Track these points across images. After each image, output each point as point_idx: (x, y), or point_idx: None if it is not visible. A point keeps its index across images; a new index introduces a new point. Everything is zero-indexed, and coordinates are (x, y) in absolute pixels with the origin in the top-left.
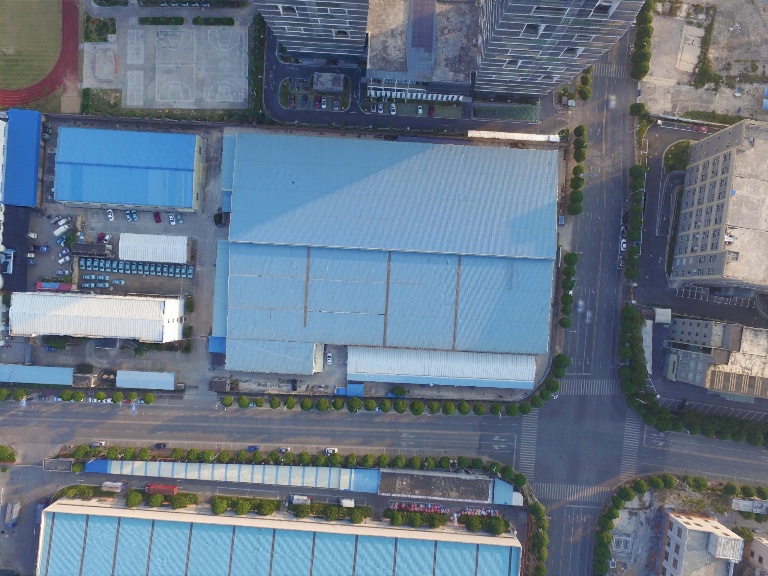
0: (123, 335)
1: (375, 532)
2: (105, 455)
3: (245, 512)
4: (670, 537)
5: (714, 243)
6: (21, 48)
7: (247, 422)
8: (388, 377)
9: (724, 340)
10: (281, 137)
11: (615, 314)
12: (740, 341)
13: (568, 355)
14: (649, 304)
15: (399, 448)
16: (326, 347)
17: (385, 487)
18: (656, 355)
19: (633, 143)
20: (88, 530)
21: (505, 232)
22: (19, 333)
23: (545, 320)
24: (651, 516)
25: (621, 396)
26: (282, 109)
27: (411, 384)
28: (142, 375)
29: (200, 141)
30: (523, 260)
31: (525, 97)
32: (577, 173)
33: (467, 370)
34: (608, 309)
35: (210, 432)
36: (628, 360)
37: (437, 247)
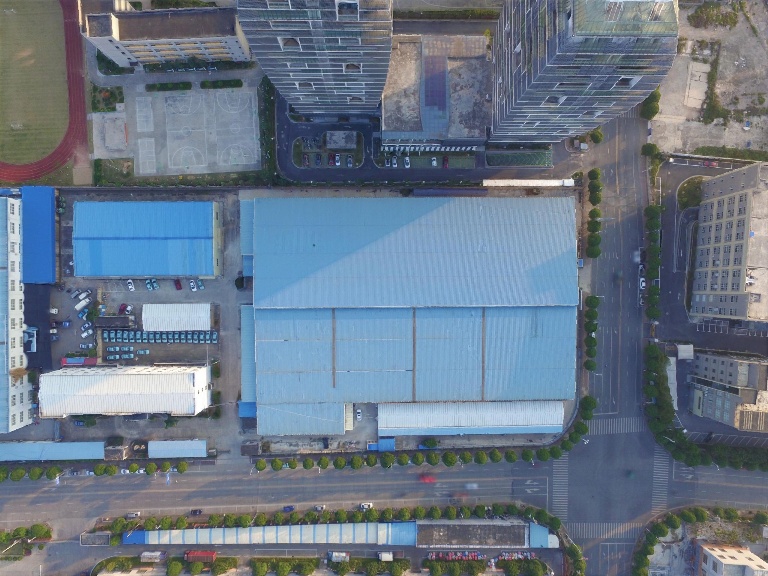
0: (154, 410)
1: None
2: (141, 525)
3: (286, 574)
4: (705, 570)
5: (735, 284)
6: (29, 122)
7: (281, 483)
8: (419, 430)
9: (750, 379)
10: (299, 200)
11: (638, 352)
12: (766, 380)
13: (594, 395)
14: (671, 340)
15: (433, 498)
16: (355, 403)
17: (422, 539)
18: (680, 390)
19: (646, 182)
20: None
21: (527, 282)
22: (50, 415)
23: (571, 365)
24: (684, 548)
25: (648, 432)
26: (296, 169)
27: (441, 434)
28: (174, 444)
29: (216, 206)
30: (546, 308)
31: (538, 144)
32: (594, 217)
33: (496, 418)
34: (631, 348)
35: (245, 495)
36: (654, 397)
37: (461, 301)
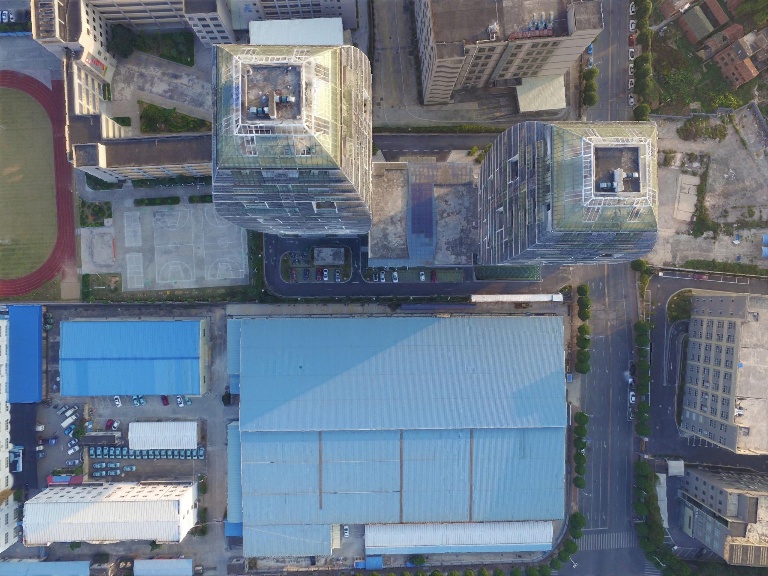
0: (139, 537)
1: None
2: None
3: None
4: None
5: (724, 412)
6: (17, 237)
7: None
8: (406, 549)
9: (740, 509)
10: (285, 321)
11: (628, 466)
12: (756, 513)
13: (584, 510)
14: (661, 455)
15: None
16: None
17: None
18: (671, 505)
19: (636, 295)
20: None
21: (515, 403)
22: (34, 543)
23: (560, 486)
24: None
25: (639, 548)
26: (284, 283)
27: None
28: (159, 563)
29: (204, 323)
30: (534, 429)
31: None
32: (582, 334)
33: (485, 537)
34: (621, 462)
35: None
36: None
37: (448, 424)
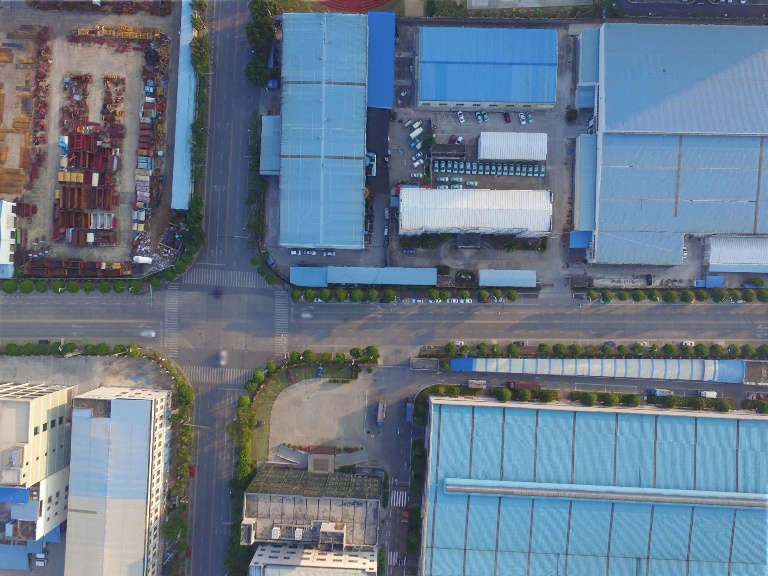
0: (511, 226)
1: (755, 417)
2: None
3: (616, 403)
4: None
5: None
6: None
7: (602, 318)
8: (750, 267)
9: None
10: (648, 26)
11: None
12: None
13: None
14: None
15: (754, 340)
16: None
17: (751, 376)
18: None
19: None
20: (475, 421)
21: None
22: (409, 228)
23: None
24: None
25: None
26: (629, 3)
27: (765, 276)
28: (504, 273)
29: None
30: None
31: None
32: None
33: None
34: None
35: (566, 329)
36: None
37: None
